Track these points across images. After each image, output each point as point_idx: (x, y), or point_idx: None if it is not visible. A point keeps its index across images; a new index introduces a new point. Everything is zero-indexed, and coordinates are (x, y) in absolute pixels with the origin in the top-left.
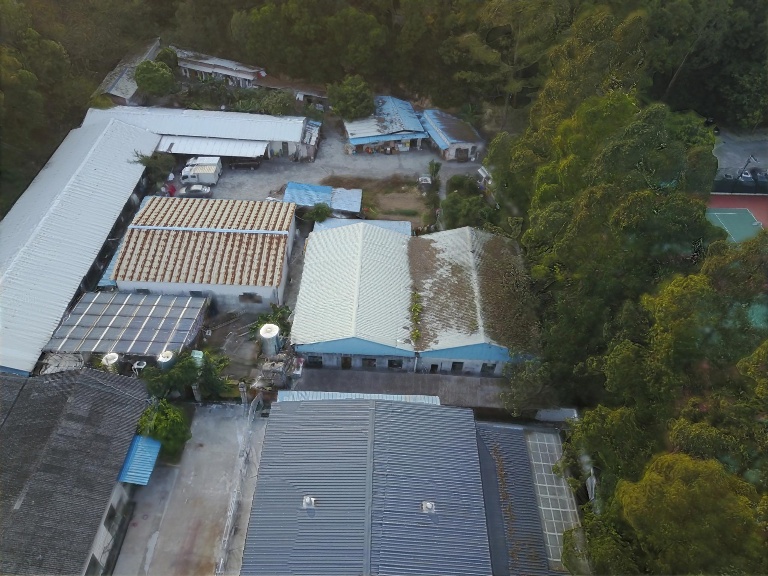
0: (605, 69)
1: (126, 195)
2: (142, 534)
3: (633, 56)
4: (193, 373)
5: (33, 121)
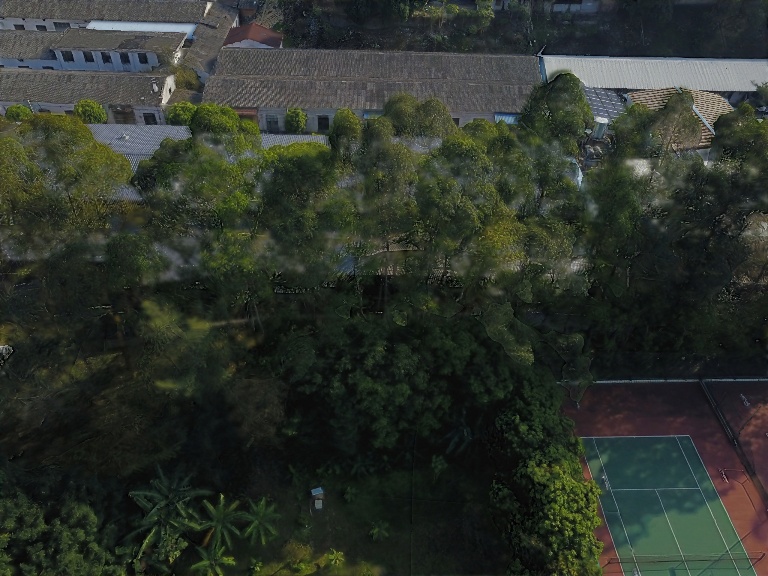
0: None
1: (715, 88)
2: None
3: None
4: None
5: (750, 34)
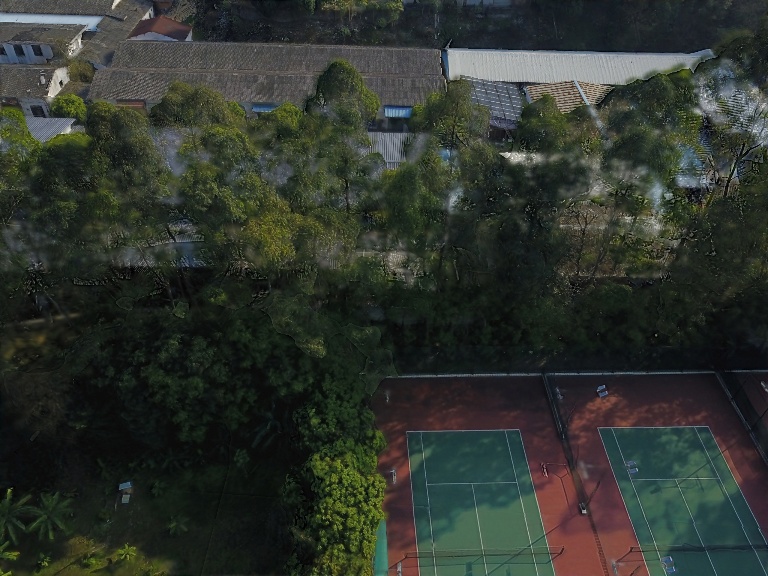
0: (725, 60)
1: (618, 82)
2: None
3: (761, 66)
4: None
5: (661, 28)
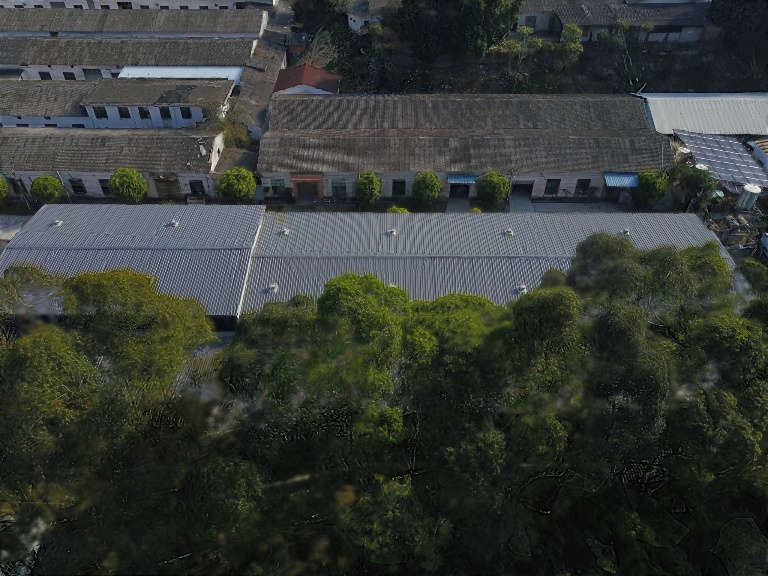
0: None
1: None
2: (581, 208)
3: None
4: (697, 183)
5: None
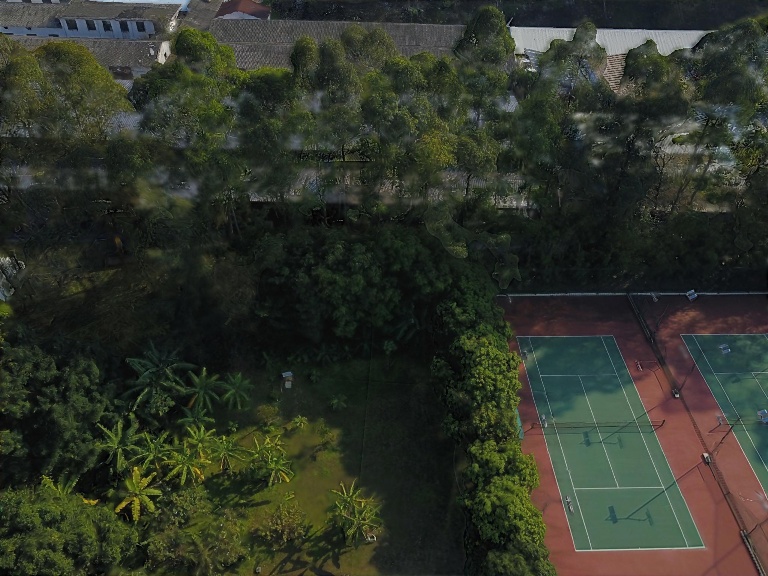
0: None
1: None
2: None
3: None
4: (527, 81)
5: (704, 8)
